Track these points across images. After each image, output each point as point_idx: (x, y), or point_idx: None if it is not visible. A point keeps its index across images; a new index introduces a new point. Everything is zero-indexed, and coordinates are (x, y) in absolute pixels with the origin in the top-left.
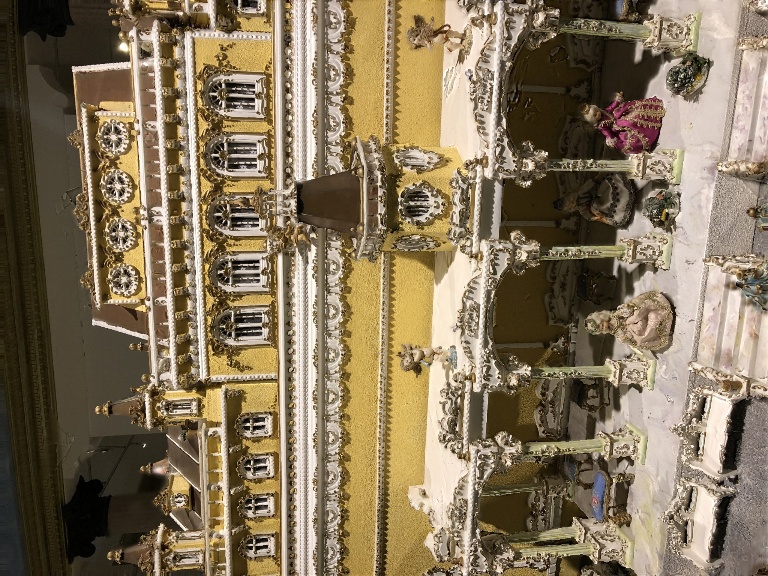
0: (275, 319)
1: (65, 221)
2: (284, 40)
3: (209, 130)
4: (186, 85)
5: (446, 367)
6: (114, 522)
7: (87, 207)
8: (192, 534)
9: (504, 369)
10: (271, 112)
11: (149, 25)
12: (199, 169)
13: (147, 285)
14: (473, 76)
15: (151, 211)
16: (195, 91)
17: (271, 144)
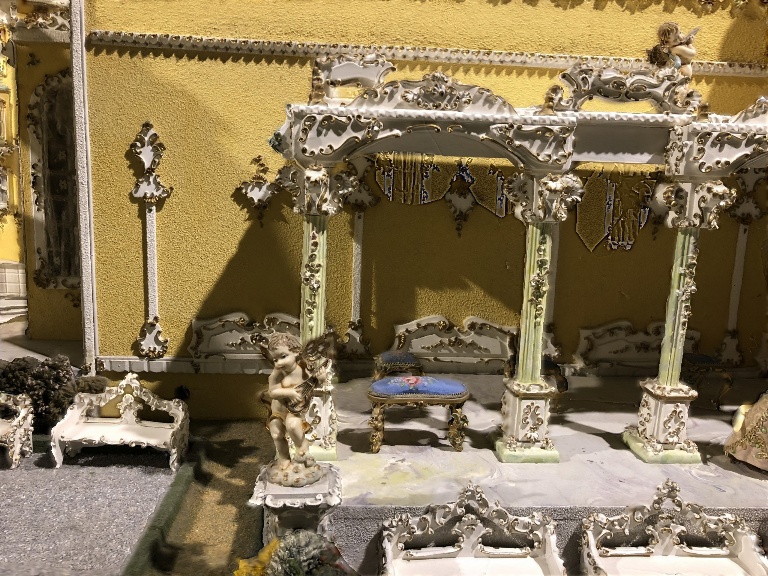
0: None
1: None
2: None
3: None
4: None
5: None
6: None
7: None
8: None
9: (719, 178)
10: None
11: None
12: None
13: None
14: None
15: None
16: None
17: None
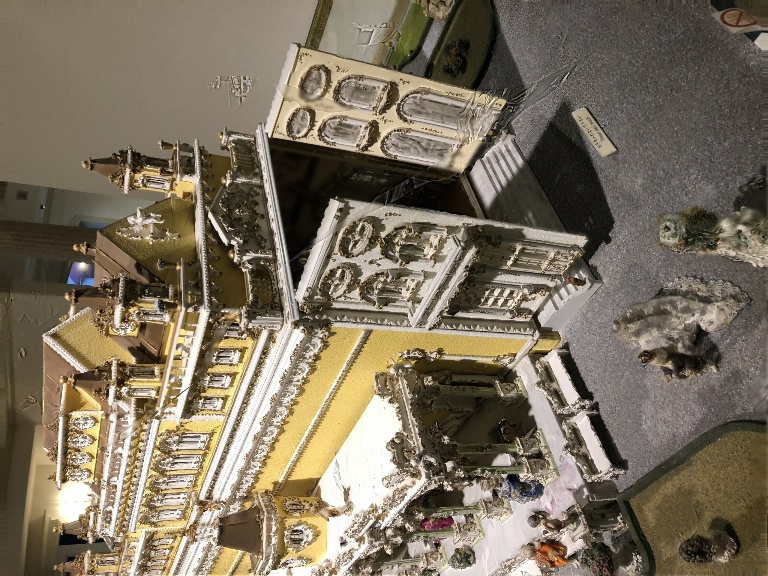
0: (186, 510)
1: (7, 323)
2: (230, 435)
3: (161, 455)
4: (149, 435)
5: (288, 569)
6: (24, 424)
7: (56, 451)
8: (107, 559)
9: None
10: (210, 445)
11: (119, 343)
12: (149, 468)
13: (100, 505)
14: (340, 556)
15: (109, 481)
16: (155, 439)
17: (205, 456)
